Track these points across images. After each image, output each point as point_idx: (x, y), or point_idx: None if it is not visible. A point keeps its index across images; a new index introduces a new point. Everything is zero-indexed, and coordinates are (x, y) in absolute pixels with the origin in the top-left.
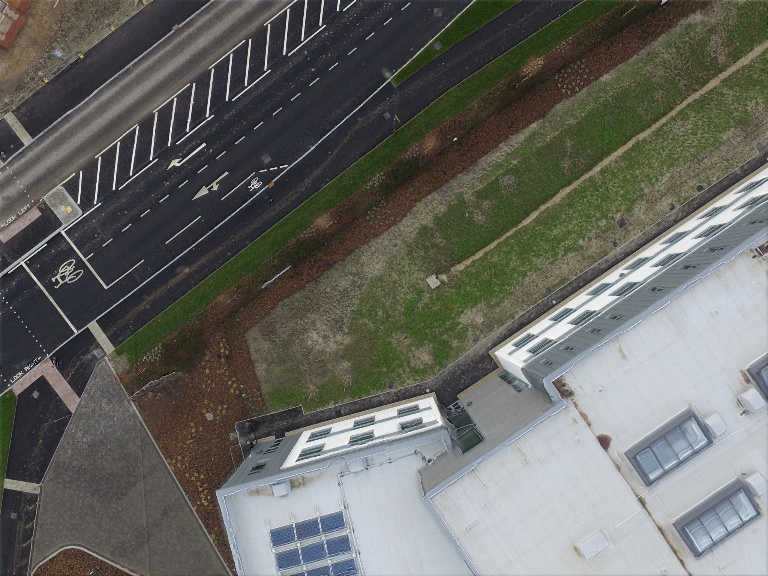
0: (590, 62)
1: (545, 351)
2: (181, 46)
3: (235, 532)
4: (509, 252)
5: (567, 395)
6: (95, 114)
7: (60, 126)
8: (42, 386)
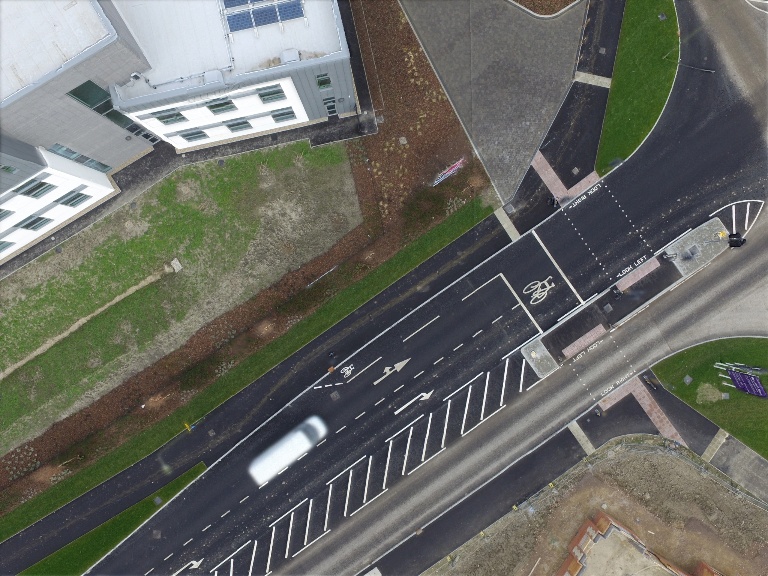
0: (4, 477)
1: (22, 182)
2: (415, 513)
3: None
4: (99, 291)
5: None
6: (505, 449)
7: (540, 439)
8: (569, 179)
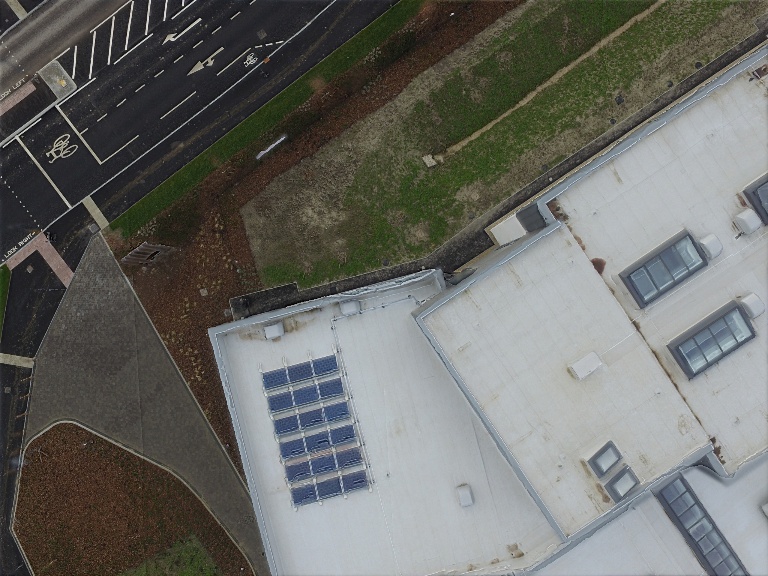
0: None
1: None
2: None
3: (227, 372)
4: (506, 132)
5: (561, 219)
6: None
7: (55, 1)
8: (36, 261)
